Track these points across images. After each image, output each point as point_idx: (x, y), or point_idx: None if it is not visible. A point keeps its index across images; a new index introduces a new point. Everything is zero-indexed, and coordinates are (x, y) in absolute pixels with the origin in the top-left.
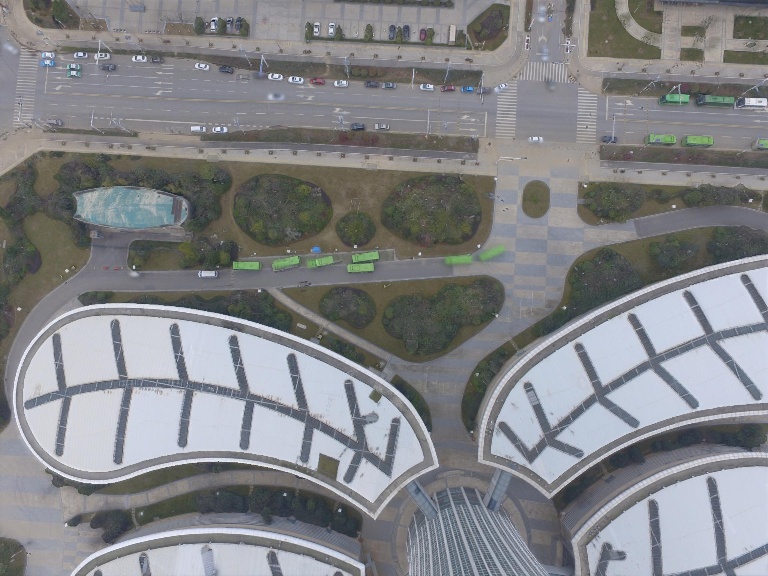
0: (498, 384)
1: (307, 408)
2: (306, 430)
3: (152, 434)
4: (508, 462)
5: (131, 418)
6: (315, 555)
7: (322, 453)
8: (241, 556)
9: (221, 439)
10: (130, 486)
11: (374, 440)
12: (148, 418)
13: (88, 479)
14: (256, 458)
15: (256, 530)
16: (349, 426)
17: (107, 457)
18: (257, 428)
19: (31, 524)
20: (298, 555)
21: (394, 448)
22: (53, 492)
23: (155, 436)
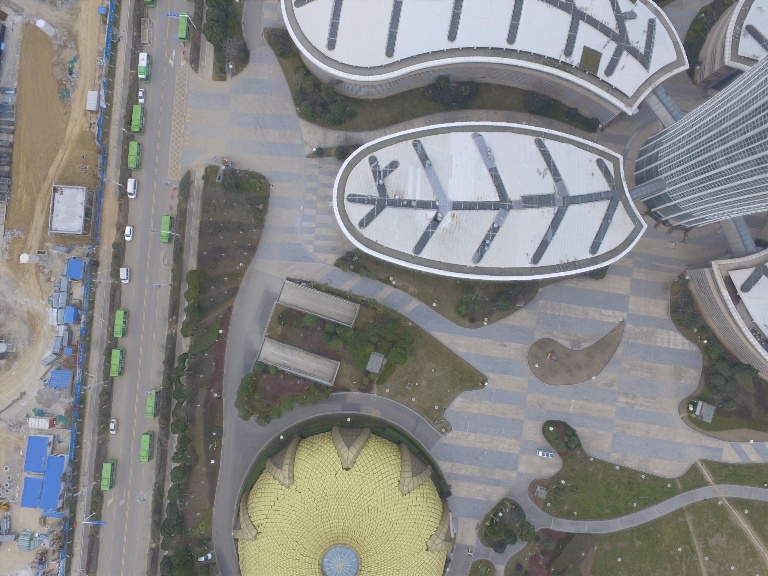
0: (738, 1)
1: (573, 1)
2: (573, 21)
3: (424, 25)
4: (754, 63)
5: (405, 9)
6: (576, 145)
7: (586, 45)
8: (511, 140)
9: (490, 32)
10: (370, 122)
11: (634, 35)
12: (422, 9)
13: (358, 75)
14: (518, 57)
15: (519, 124)
16: (612, 20)
17: (379, 49)
18: (526, 19)
19: (273, 158)
20: (562, 143)
21: (651, 45)
22: (293, 128)
23: (427, 28)
